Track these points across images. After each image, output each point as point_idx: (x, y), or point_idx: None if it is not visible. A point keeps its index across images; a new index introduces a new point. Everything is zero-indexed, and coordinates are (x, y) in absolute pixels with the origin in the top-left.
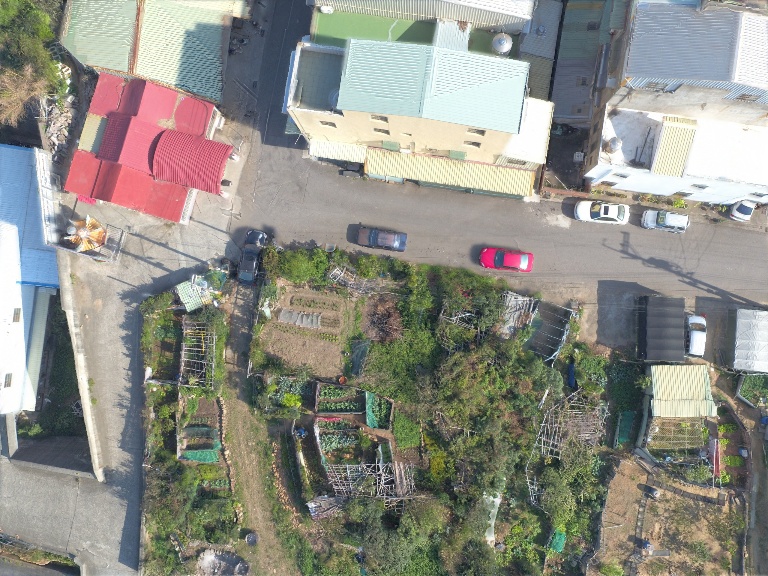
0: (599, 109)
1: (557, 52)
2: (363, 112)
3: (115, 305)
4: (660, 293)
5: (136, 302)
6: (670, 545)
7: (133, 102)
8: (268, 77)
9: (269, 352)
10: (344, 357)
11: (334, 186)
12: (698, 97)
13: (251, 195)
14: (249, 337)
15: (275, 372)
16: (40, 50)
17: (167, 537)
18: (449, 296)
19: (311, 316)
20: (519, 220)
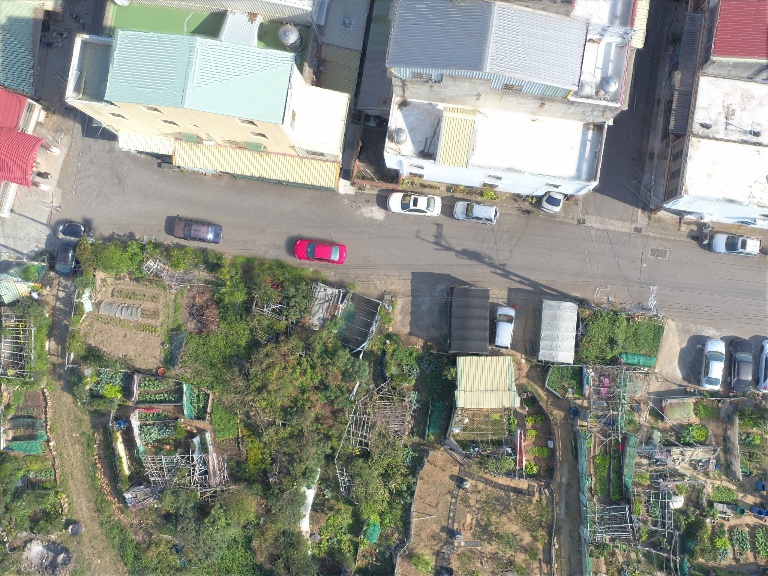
0: None
1: (366, 44)
2: (131, 103)
3: None
4: (473, 285)
5: None
6: (482, 536)
7: None
8: None
9: (91, 344)
10: (164, 349)
11: (153, 178)
12: (468, 87)
13: (71, 187)
14: None
15: (93, 363)
16: None
17: None
18: (259, 288)
19: (131, 308)
20: (334, 212)
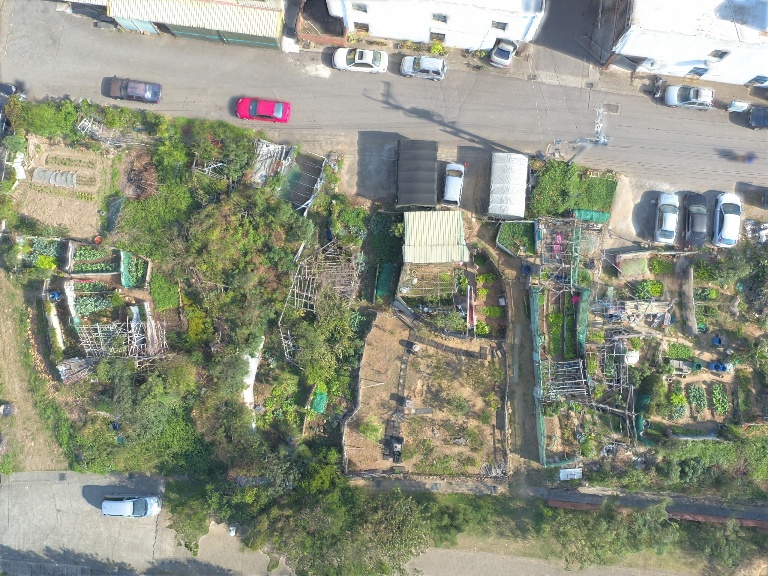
0: None
1: None
2: None
3: None
4: None
5: None
6: (433, 403)
7: None
8: None
9: (23, 213)
10: (100, 216)
11: (88, 39)
12: None
13: (2, 49)
14: None
15: (25, 230)
16: None
17: None
18: (199, 145)
19: (66, 174)
20: (278, 71)
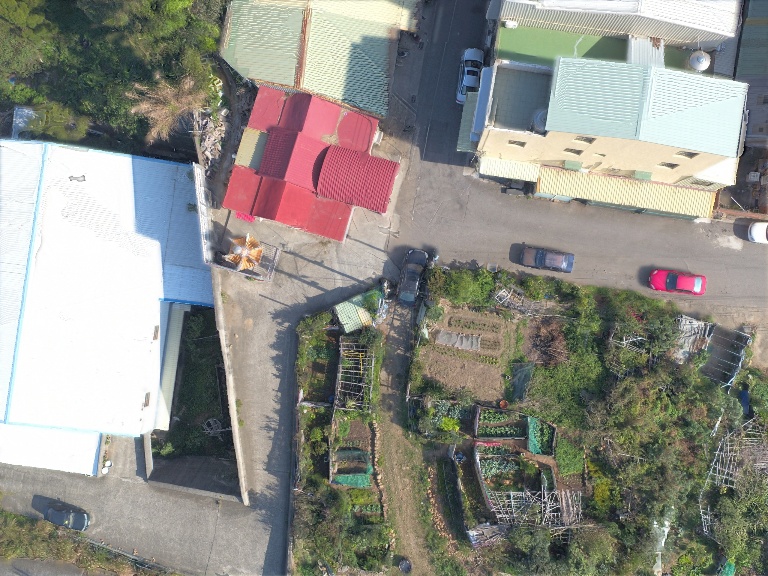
0: None
1: (735, 69)
2: (573, 133)
3: (266, 325)
4: None
5: (288, 322)
6: None
7: (297, 117)
8: (428, 91)
9: (426, 374)
10: (504, 380)
11: (496, 204)
12: None
13: (410, 213)
14: (405, 359)
15: (435, 395)
16: (198, 62)
17: (313, 562)
18: (621, 319)
19: (471, 338)
20: (689, 241)
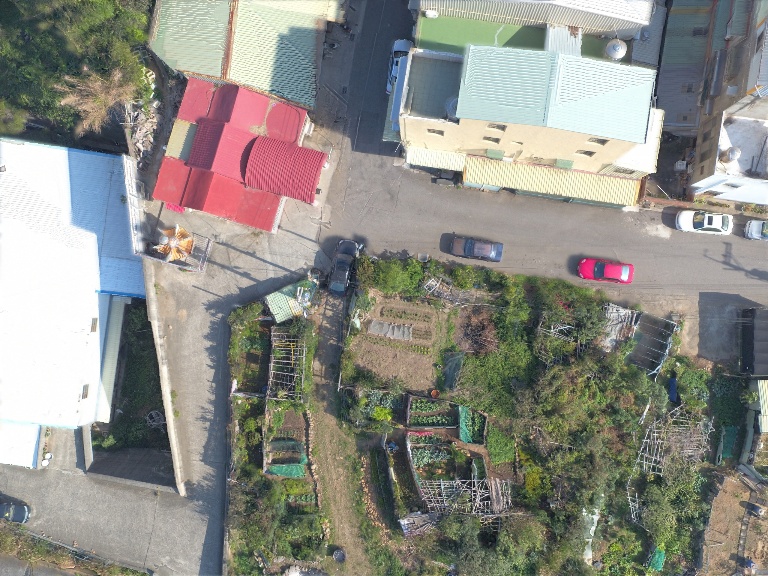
0: (711, 117)
1: (660, 58)
2: (483, 120)
3: (200, 316)
4: (763, 305)
5: (222, 313)
6: None
7: (225, 108)
8: (358, 82)
9: (358, 364)
10: (436, 370)
11: (427, 194)
12: None
13: (341, 203)
14: (338, 349)
15: (366, 385)
16: (127, 54)
17: (250, 553)
18: (548, 308)
19: (402, 328)
20: (618, 230)
